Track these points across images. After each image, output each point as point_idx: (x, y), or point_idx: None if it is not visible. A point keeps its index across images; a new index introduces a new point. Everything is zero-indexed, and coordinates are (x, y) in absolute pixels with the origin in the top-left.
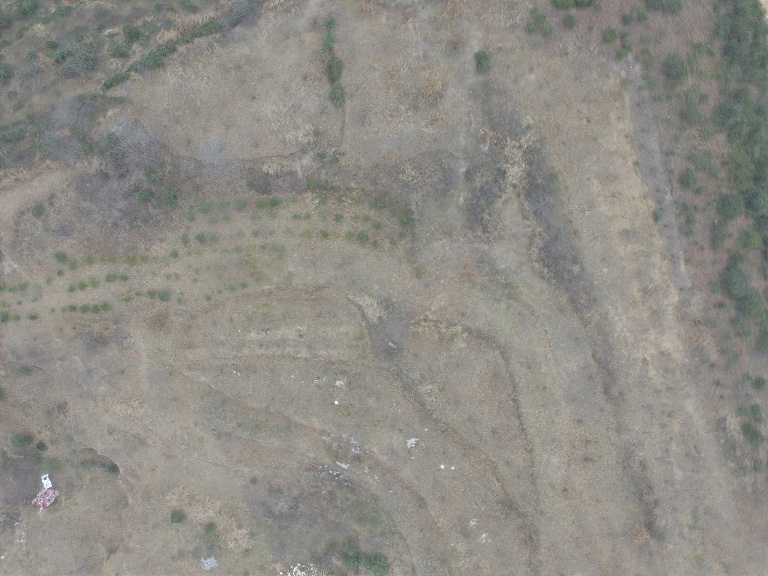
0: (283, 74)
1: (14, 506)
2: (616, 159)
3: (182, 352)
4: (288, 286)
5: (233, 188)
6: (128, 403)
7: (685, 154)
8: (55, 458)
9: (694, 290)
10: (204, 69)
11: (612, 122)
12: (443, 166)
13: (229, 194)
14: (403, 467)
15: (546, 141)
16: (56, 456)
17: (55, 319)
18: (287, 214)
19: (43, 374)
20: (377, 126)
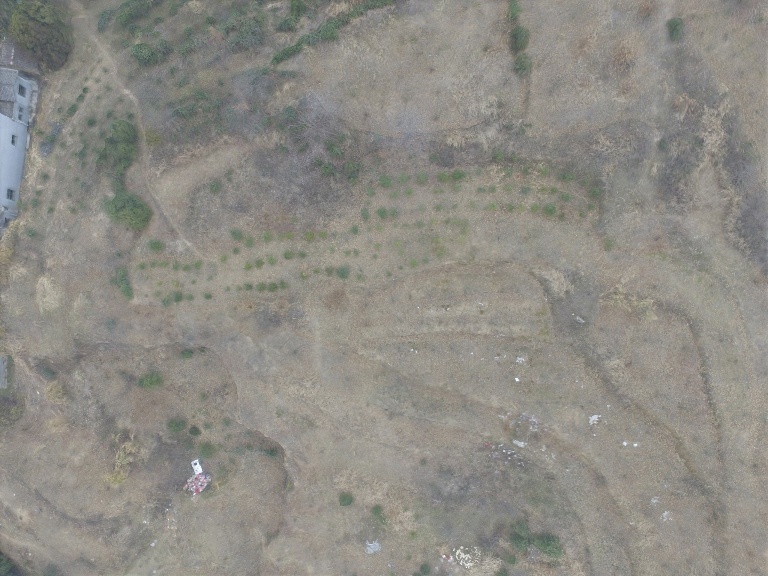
0: (462, 45)
1: (165, 492)
2: None
3: (358, 330)
4: (470, 261)
5: (414, 162)
6: (301, 383)
7: None
8: (207, 443)
9: None
10: (379, 41)
11: None
12: (637, 135)
13: (410, 168)
14: (584, 445)
15: (739, 109)
16: (209, 441)
17: (229, 298)
18: (470, 187)
19: (204, 356)
20: (565, 96)
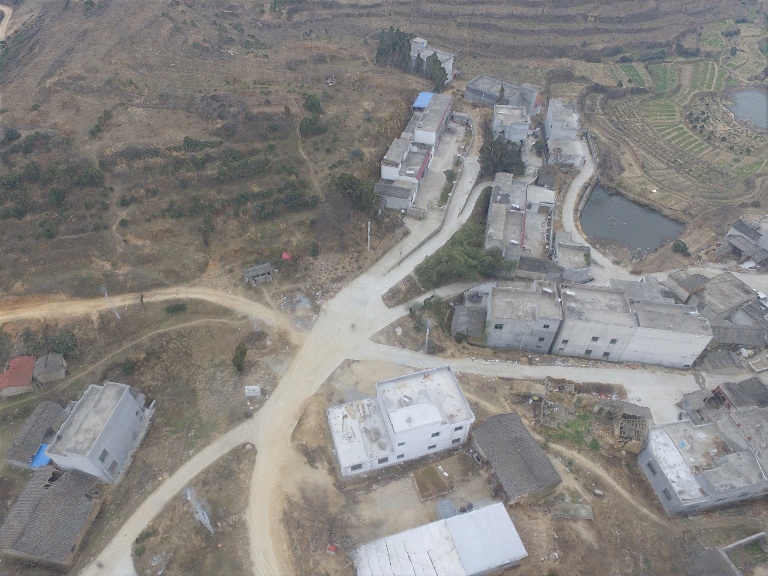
0: None
1: None
2: None
3: None
4: None
5: None
6: None
7: None
8: None
9: None
10: None
11: None
12: None
13: None
14: None
15: None
16: None
17: None
18: None
19: None
20: None
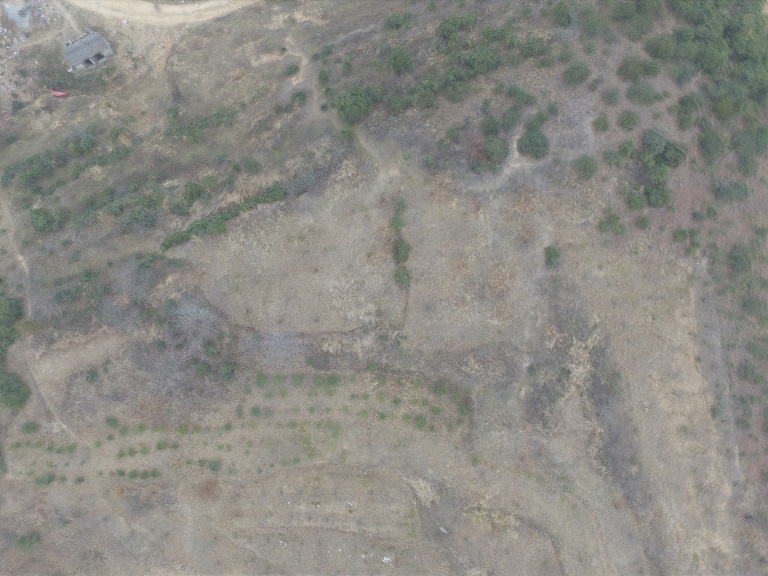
0: (347, 248)
1: None
2: (678, 356)
3: (229, 519)
4: (341, 463)
5: (291, 363)
6: (171, 565)
7: (744, 345)
8: None
9: (747, 485)
10: (266, 236)
11: (677, 320)
12: (507, 360)
13: (286, 368)
14: None
15: (611, 338)
16: None
17: (102, 481)
18: (344, 392)
19: None
20: (441, 312)
